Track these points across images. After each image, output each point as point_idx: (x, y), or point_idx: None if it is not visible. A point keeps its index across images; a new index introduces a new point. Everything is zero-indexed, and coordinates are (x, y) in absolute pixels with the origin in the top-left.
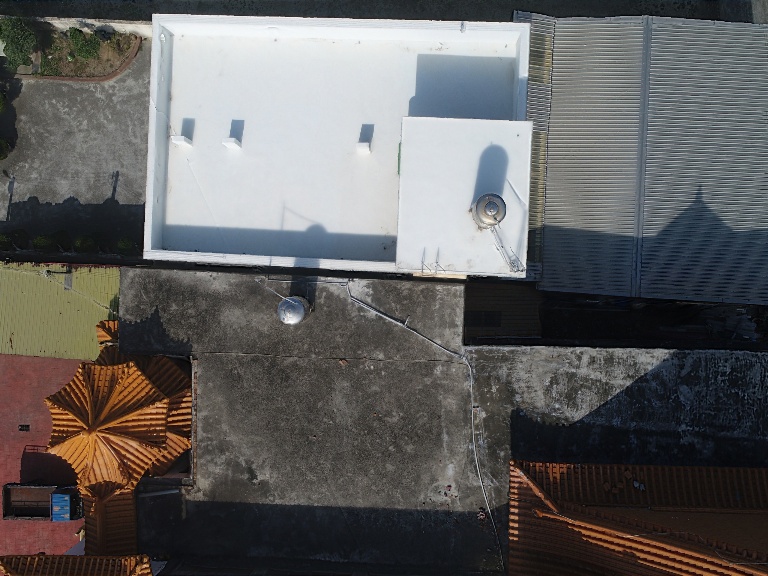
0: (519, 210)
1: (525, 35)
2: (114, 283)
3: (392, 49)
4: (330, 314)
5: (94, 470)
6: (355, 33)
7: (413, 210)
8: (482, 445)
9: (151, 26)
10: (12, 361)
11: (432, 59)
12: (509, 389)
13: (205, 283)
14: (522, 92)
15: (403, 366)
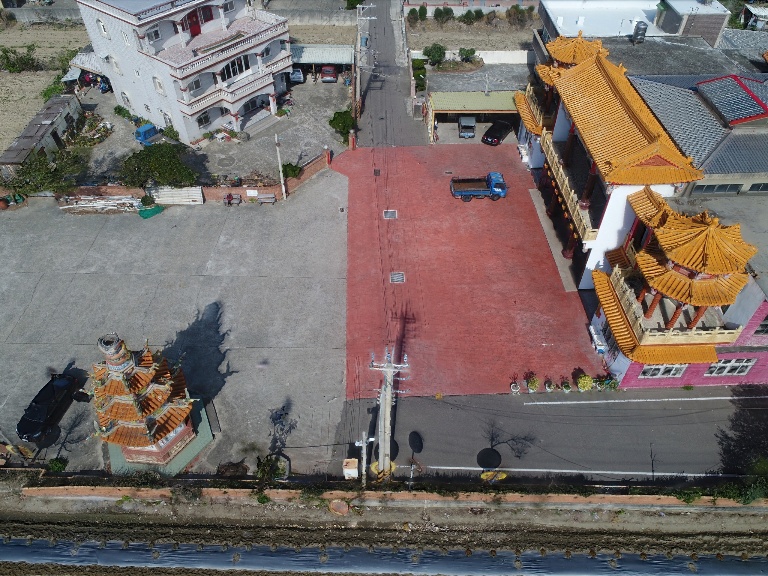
0: (717, 3)
1: None
2: (511, 94)
3: (631, 9)
4: (650, 44)
5: (577, 59)
6: (617, 3)
7: (677, 4)
8: (744, 68)
9: (494, 52)
10: (436, 150)
11: (648, 10)
12: (743, 56)
13: (591, 40)
14: None
15: (692, 53)
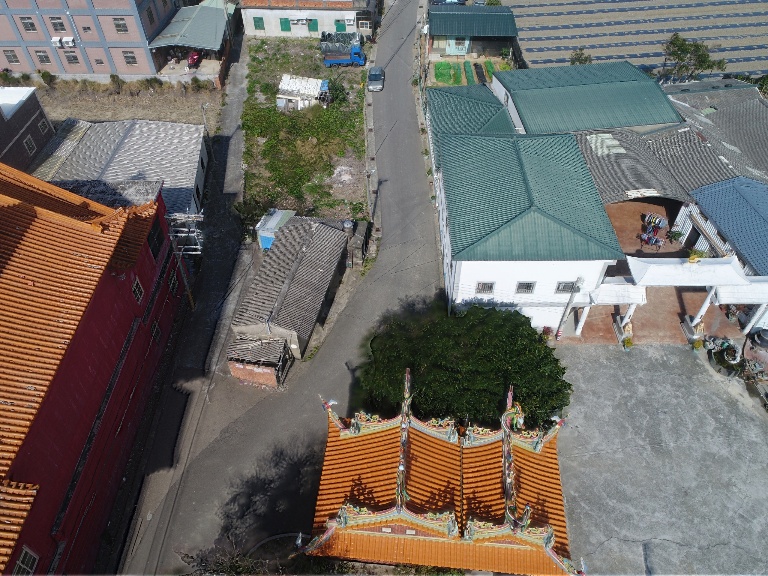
0: None
1: (31, 90)
2: None
3: None
4: None
5: None
6: None
7: None
8: None
9: None
10: None
11: None
12: None
13: None
14: (18, 104)
15: None
